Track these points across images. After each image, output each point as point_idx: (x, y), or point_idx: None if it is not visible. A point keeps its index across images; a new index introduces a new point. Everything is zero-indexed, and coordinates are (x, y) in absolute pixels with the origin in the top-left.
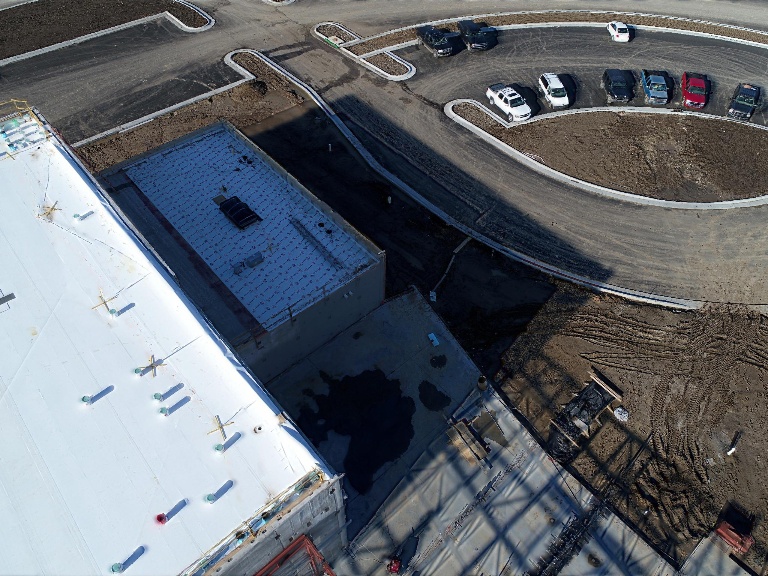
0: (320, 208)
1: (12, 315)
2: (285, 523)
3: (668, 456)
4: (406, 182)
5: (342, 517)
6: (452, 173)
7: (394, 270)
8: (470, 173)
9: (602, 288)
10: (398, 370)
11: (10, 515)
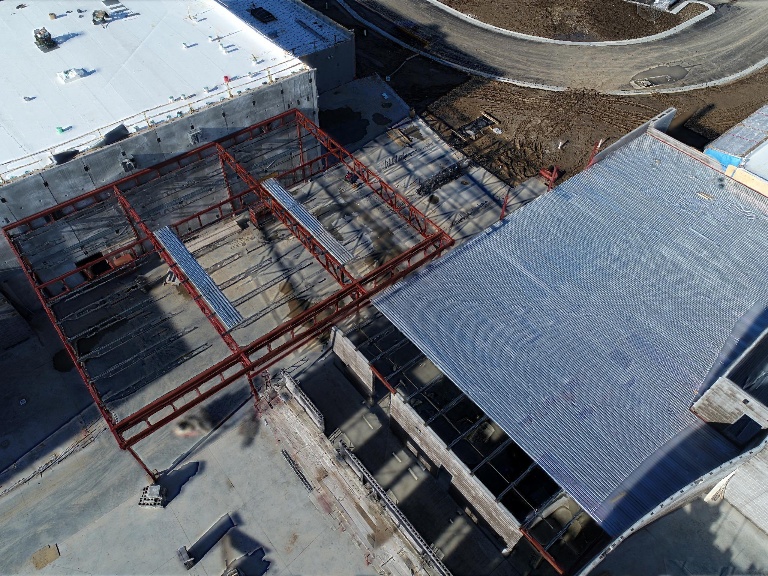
0: (315, 14)
1: (140, 20)
2: (286, 82)
3: (522, 148)
4: (379, 27)
5: (317, 123)
6: (412, 23)
7: (364, 67)
8: (424, 23)
9: (502, 79)
10: (361, 108)
11: (152, 76)
